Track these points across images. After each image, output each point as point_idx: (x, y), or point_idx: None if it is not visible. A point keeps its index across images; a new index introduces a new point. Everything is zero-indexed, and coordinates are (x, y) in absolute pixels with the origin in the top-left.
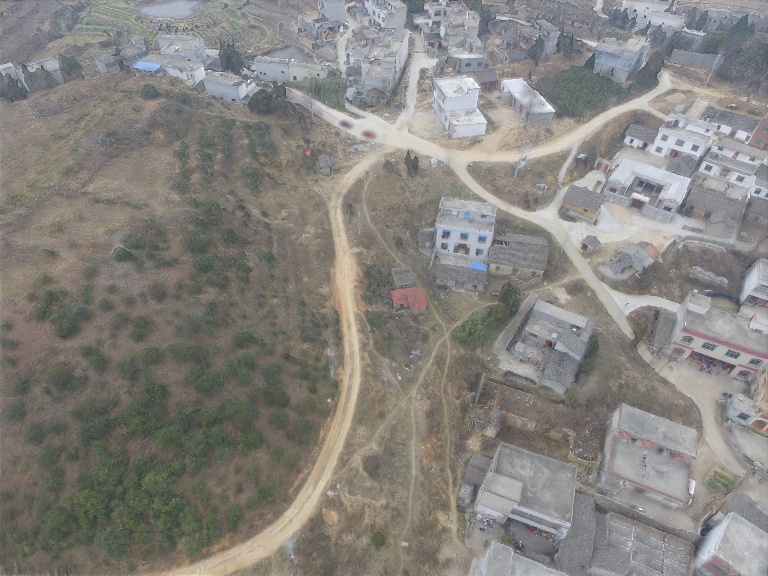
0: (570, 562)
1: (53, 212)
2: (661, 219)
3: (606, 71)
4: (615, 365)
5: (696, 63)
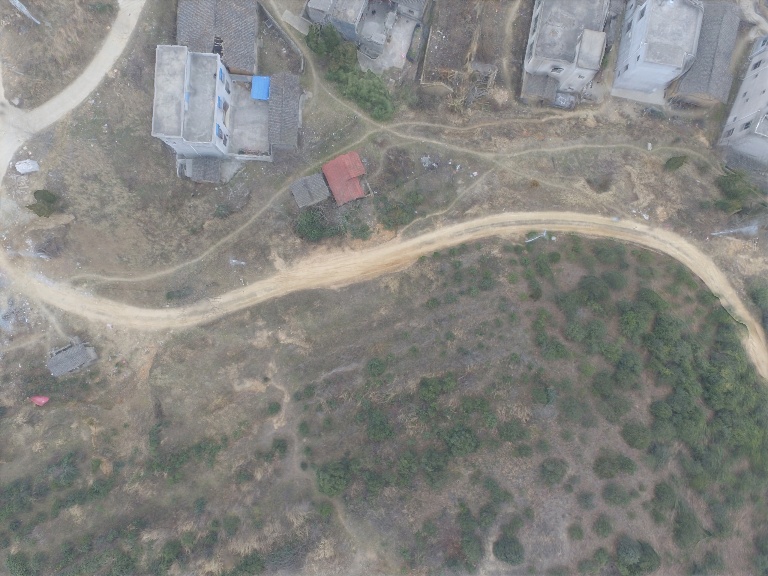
0: (617, 1)
1: None
2: None
3: None
4: None
5: None
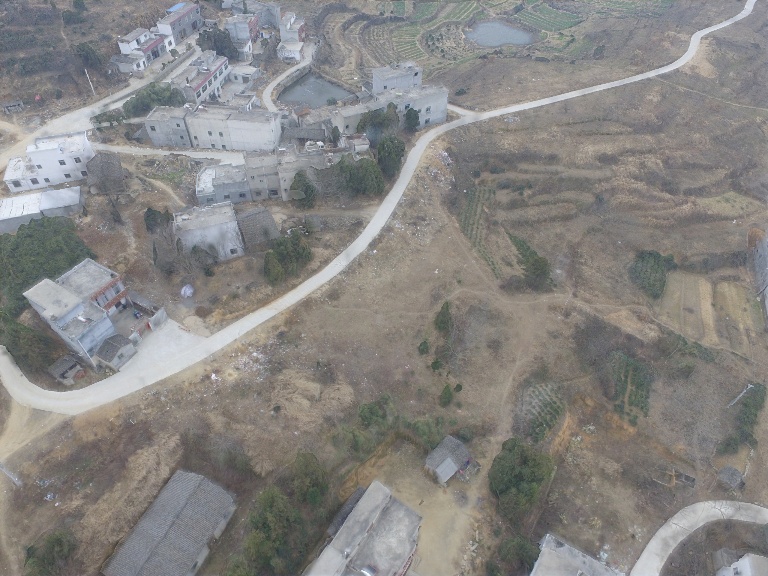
0: None
1: None
2: None
3: None
4: None
5: (142, 517)
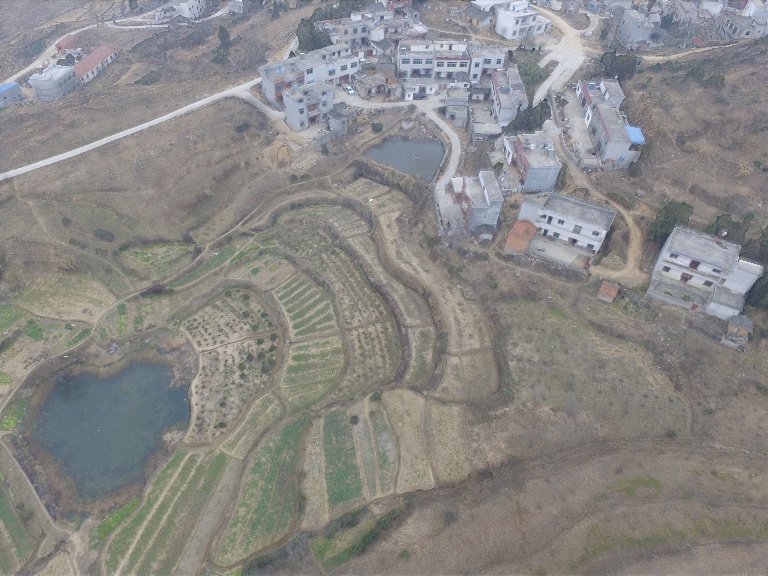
0: None
1: None
2: (550, 2)
3: None
4: None
5: None
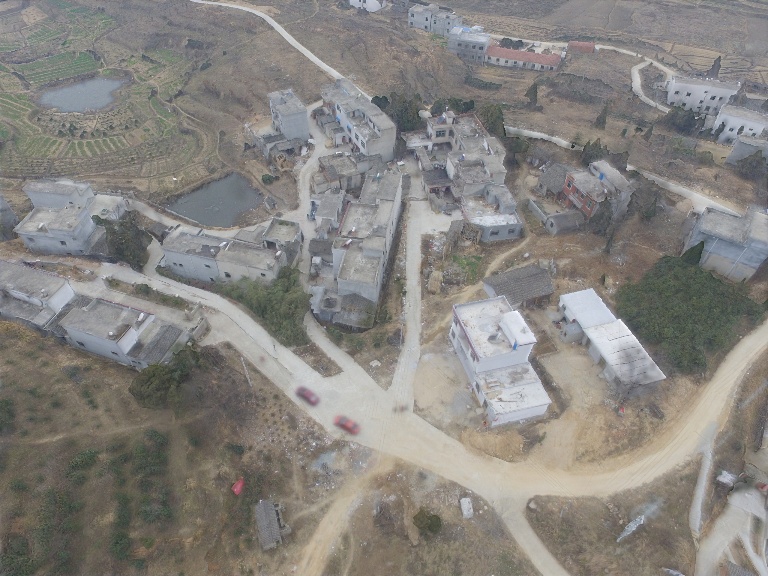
0: None
1: None
2: None
3: (717, 261)
4: None
5: None
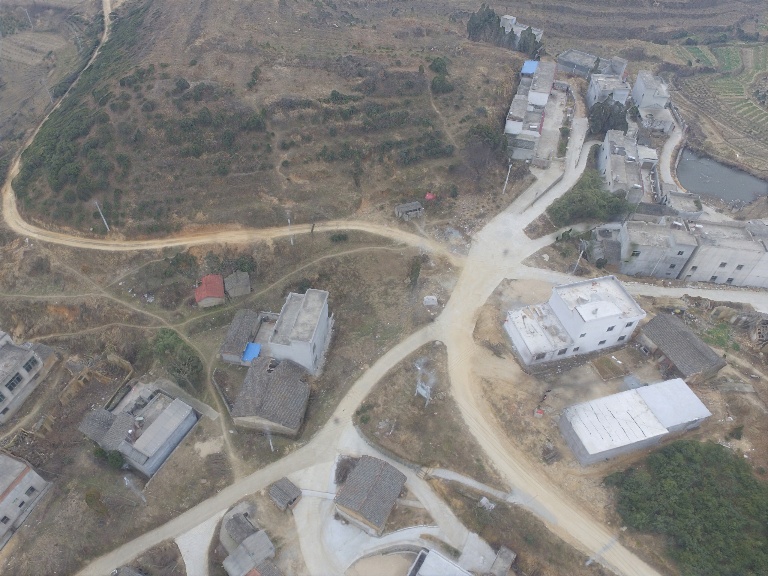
0: None
1: (244, 59)
2: None
3: None
4: (91, 487)
5: None
